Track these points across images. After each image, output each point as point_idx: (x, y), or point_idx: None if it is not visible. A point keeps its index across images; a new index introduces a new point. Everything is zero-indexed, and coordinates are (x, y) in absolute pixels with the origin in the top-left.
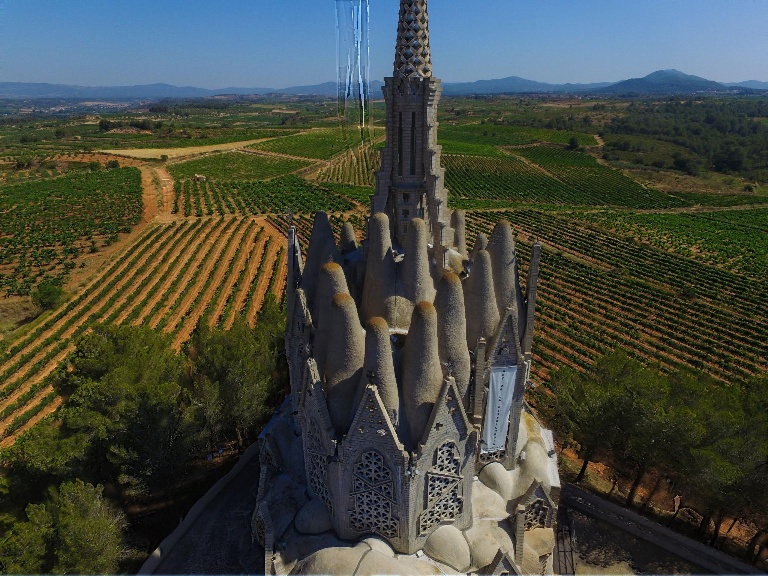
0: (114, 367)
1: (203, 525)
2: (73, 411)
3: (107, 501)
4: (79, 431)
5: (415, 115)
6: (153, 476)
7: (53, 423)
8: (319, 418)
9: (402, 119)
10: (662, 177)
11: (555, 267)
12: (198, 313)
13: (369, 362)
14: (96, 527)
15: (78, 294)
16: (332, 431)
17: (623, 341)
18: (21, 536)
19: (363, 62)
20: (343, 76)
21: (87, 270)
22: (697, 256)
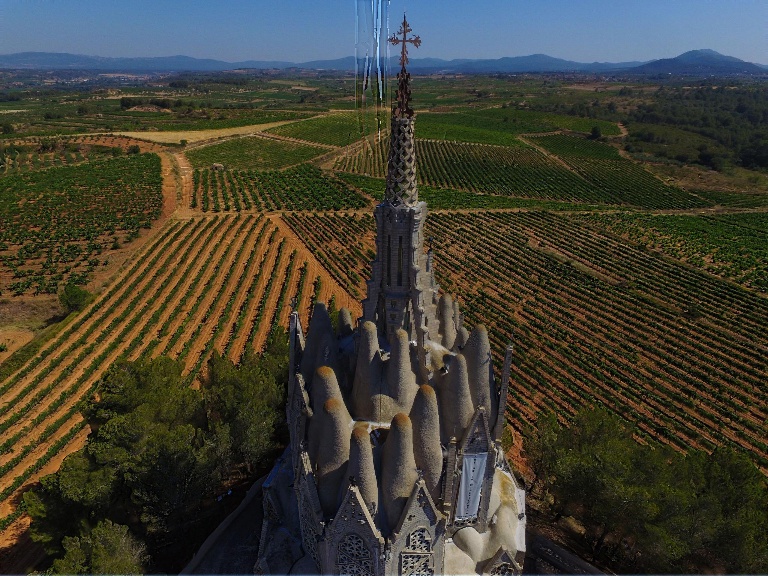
0: (137, 401)
1: (213, 559)
2: (101, 447)
3: (131, 534)
4: (106, 464)
5: (402, 239)
6: (170, 515)
7: (84, 455)
8: (311, 500)
9: (391, 241)
10: (684, 174)
11: (563, 278)
12: (214, 320)
13: (352, 464)
14: (122, 568)
15: (102, 295)
16: (321, 514)
17: (620, 366)
18: (60, 574)
19: (382, 52)
20: (361, 68)
21: (110, 268)
22: (709, 267)
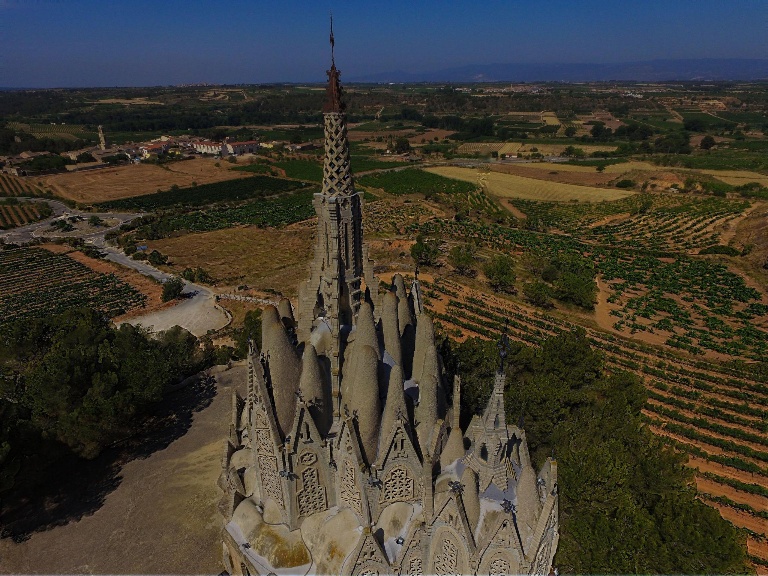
0: None
1: None
2: None
3: None
4: None
5: None
6: None
7: None
8: None
9: None
10: None
11: None
12: None
13: None
14: None
15: None
16: None
17: None
18: None
19: None
20: None
21: None
22: None
